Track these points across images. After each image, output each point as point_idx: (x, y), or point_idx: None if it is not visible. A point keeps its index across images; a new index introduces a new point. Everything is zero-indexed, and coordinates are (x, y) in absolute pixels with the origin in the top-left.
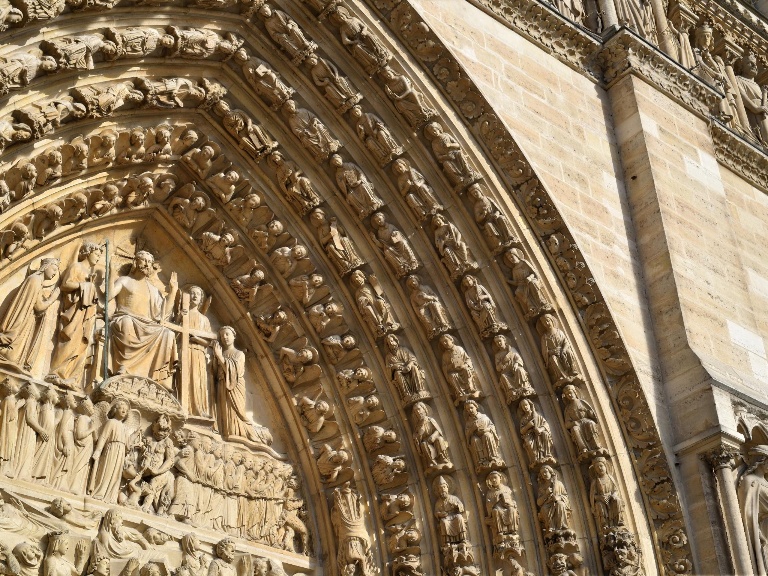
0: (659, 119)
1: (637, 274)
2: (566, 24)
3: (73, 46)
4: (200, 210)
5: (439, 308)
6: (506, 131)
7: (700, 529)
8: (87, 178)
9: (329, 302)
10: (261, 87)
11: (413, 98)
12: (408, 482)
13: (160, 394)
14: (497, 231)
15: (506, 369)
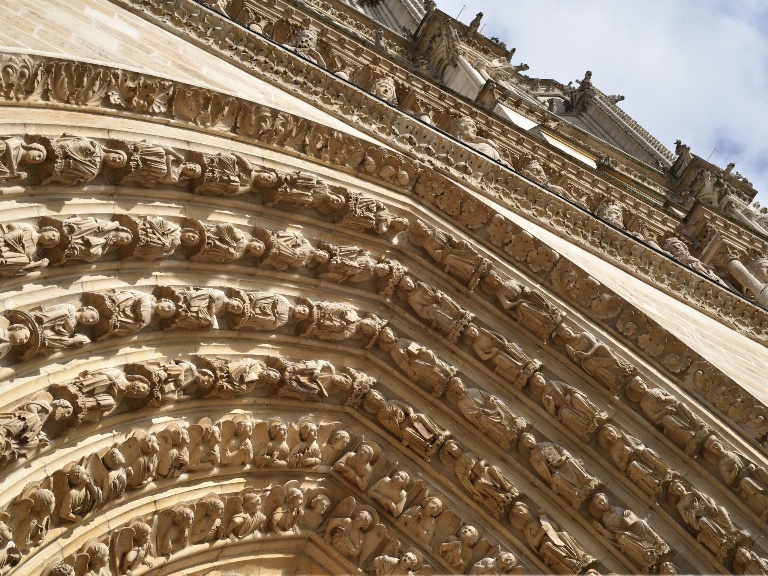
0: None
1: None
2: (742, 301)
3: (193, 292)
4: (366, 529)
5: None
6: (726, 378)
7: None
8: (220, 482)
9: None
10: (417, 367)
11: (604, 351)
12: None
13: None
14: (760, 486)
15: None
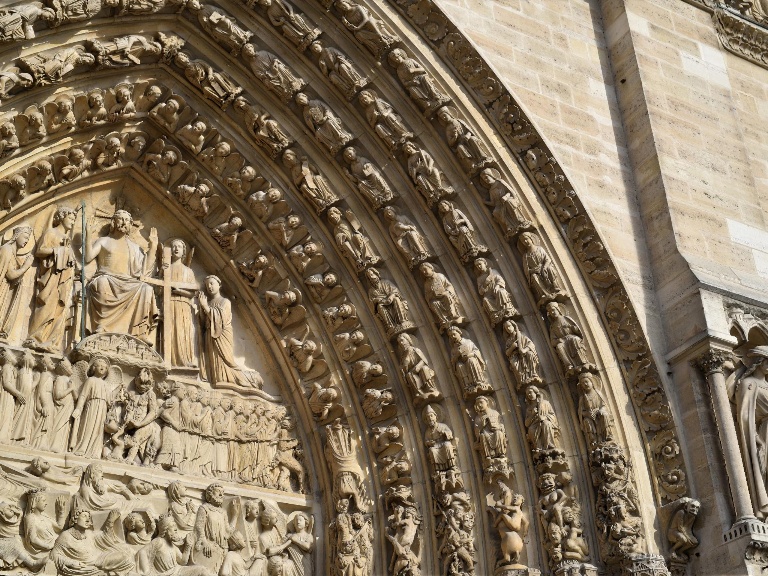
0: (651, 16)
1: (627, 181)
2: None
3: (7, 18)
4: (173, 164)
5: (416, 237)
6: (473, 49)
7: (692, 438)
8: (50, 145)
9: (307, 242)
10: (217, 34)
11: (371, 27)
12: (398, 414)
13: (140, 349)
14: (469, 153)
15: (488, 292)
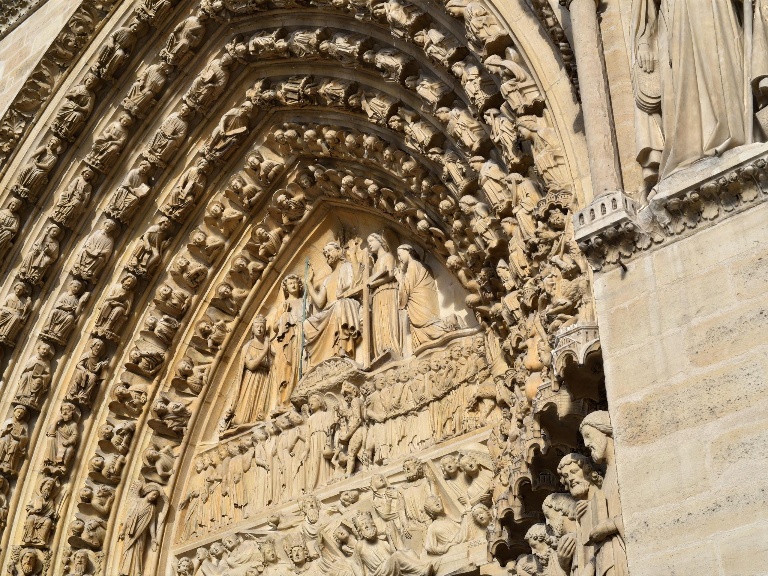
0: None
1: None
2: None
3: None
4: (328, 178)
5: (424, 91)
6: None
7: None
8: (237, 244)
9: None
10: None
11: None
12: None
13: (338, 365)
14: None
15: None
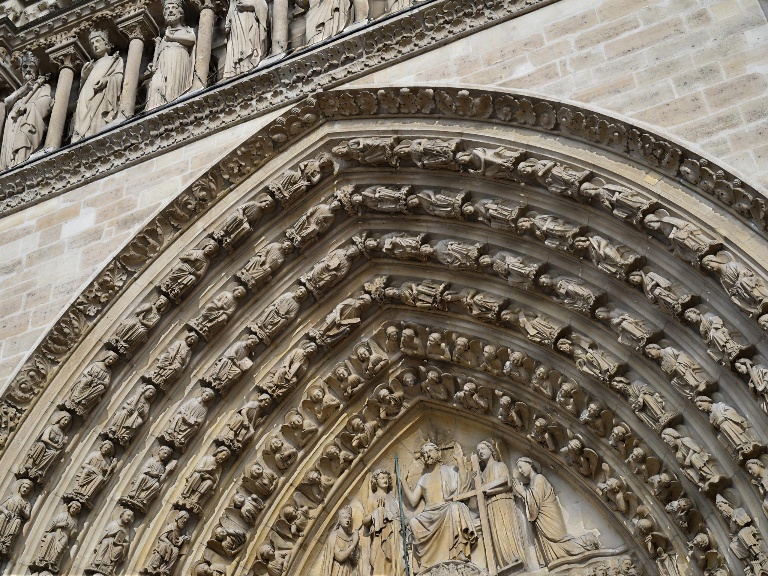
0: None
1: None
2: None
3: None
4: (440, 381)
5: (628, 325)
6: (583, 111)
7: None
8: (330, 431)
9: (561, 385)
10: (398, 256)
11: (488, 162)
12: (704, 516)
13: (459, 569)
14: (624, 213)
15: None
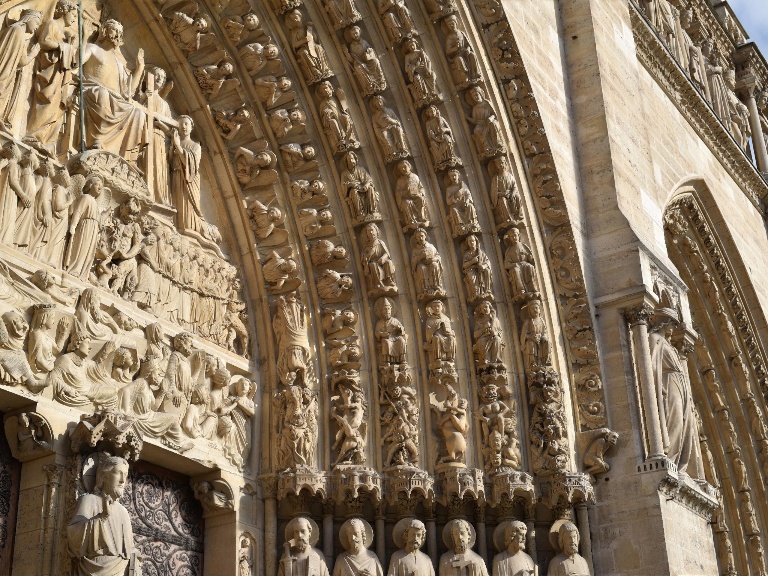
0: None
1: (571, 131)
2: None
3: None
4: None
5: (402, 133)
6: None
7: (614, 377)
8: None
9: (294, 108)
10: None
11: None
12: (351, 299)
13: (131, 176)
14: (466, 66)
15: (457, 203)
